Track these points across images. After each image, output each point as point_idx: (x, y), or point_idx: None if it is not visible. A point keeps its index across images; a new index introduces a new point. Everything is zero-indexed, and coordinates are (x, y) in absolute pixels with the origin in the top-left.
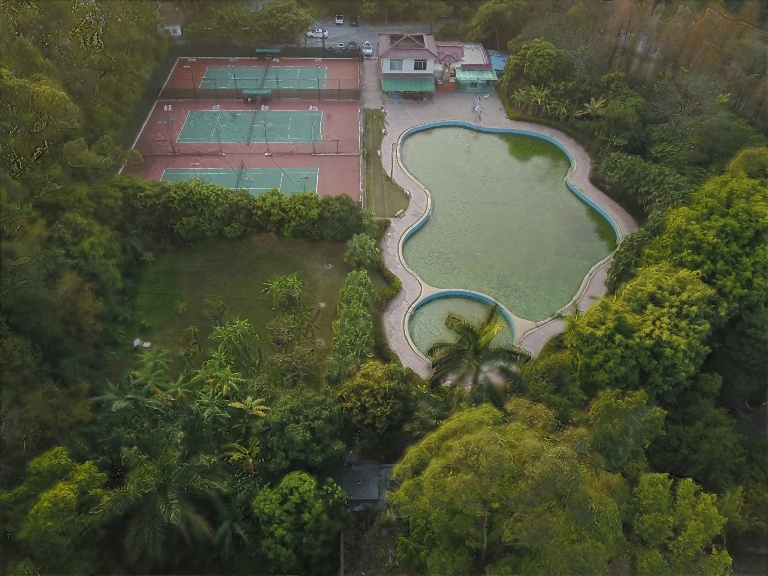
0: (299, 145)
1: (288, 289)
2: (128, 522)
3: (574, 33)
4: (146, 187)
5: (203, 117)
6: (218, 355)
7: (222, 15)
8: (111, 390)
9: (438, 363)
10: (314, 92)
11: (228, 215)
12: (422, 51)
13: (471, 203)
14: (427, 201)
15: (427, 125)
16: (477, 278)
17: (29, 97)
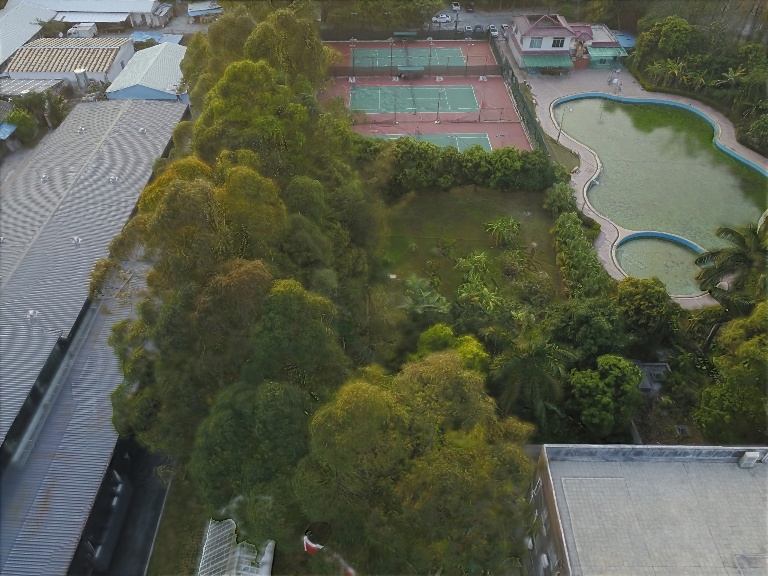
0: (462, 114)
1: (509, 229)
2: (503, 383)
3: (702, 11)
4: (373, 142)
5: (365, 92)
6: (472, 279)
7: (366, 1)
8: (406, 302)
9: (725, 263)
10: (462, 68)
11: (441, 167)
12: (561, 29)
13: (633, 162)
14: (596, 160)
15: (571, 96)
16: (661, 223)
17: (323, 54)
